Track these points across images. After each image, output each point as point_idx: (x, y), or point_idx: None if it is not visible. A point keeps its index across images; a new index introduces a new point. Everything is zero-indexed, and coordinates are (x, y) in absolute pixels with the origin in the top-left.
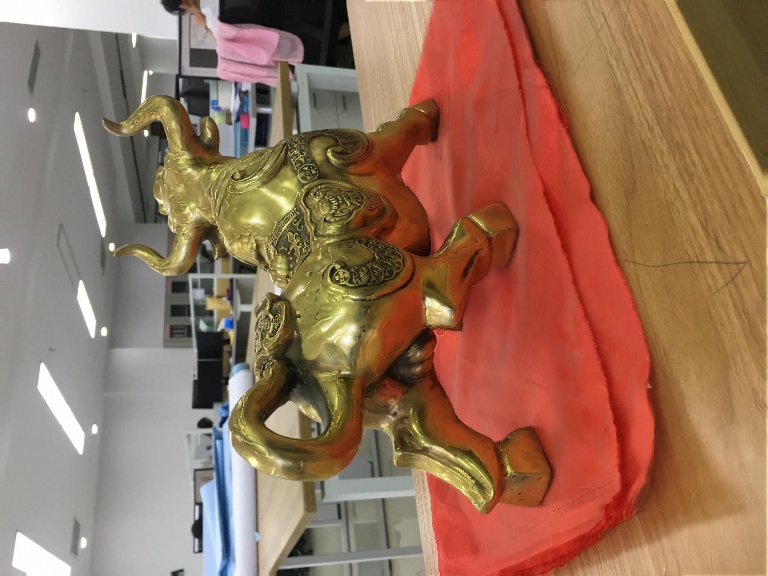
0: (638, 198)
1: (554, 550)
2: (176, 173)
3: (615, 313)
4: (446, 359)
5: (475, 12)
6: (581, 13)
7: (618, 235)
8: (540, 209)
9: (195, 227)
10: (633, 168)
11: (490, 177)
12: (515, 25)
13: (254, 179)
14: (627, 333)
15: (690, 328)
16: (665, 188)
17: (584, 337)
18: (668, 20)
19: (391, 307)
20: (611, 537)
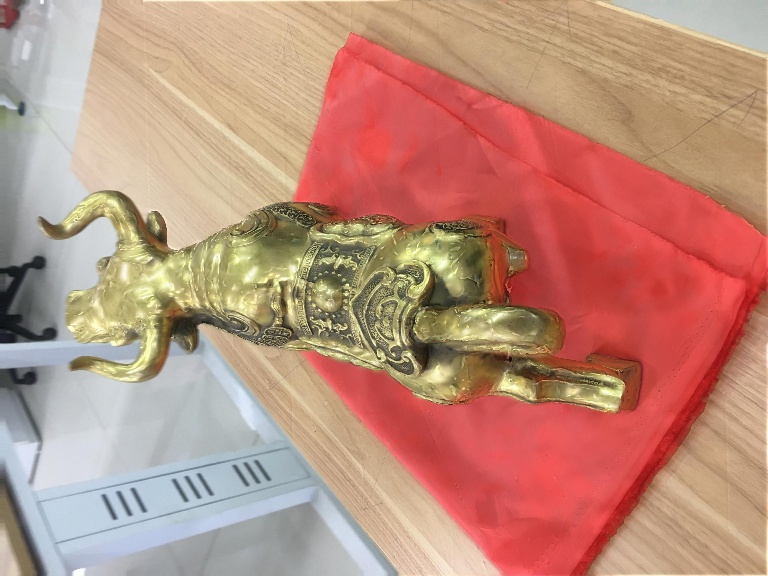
0: (638, 118)
1: (685, 410)
2: (134, 264)
3: (654, 197)
4: (431, 403)
5: (380, 105)
6: (517, 51)
7: (629, 151)
8: (533, 184)
9: (166, 317)
10: (623, 104)
11: (450, 204)
12: (438, 92)
13: (259, 230)
14: (674, 200)
15: (732, 156)
16: (661, 97)
17: (631, 232)
18: (613, 14)
19: (496, 244)
20: (735, 350)
